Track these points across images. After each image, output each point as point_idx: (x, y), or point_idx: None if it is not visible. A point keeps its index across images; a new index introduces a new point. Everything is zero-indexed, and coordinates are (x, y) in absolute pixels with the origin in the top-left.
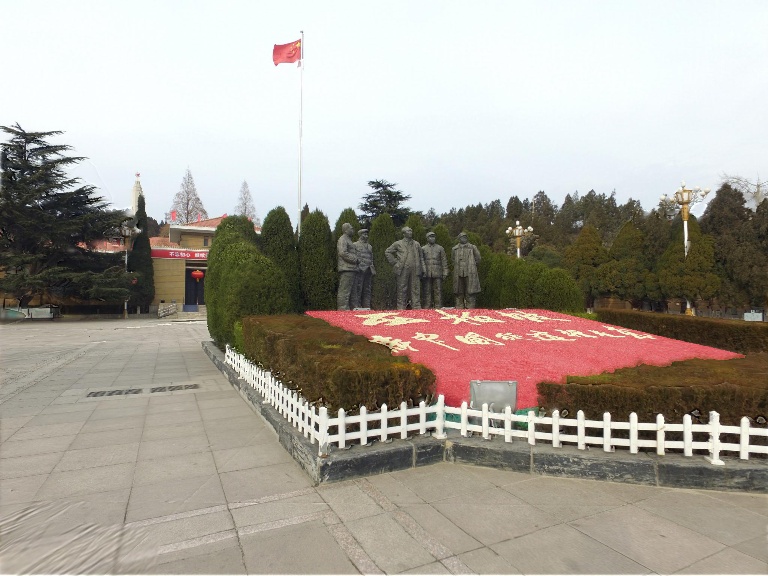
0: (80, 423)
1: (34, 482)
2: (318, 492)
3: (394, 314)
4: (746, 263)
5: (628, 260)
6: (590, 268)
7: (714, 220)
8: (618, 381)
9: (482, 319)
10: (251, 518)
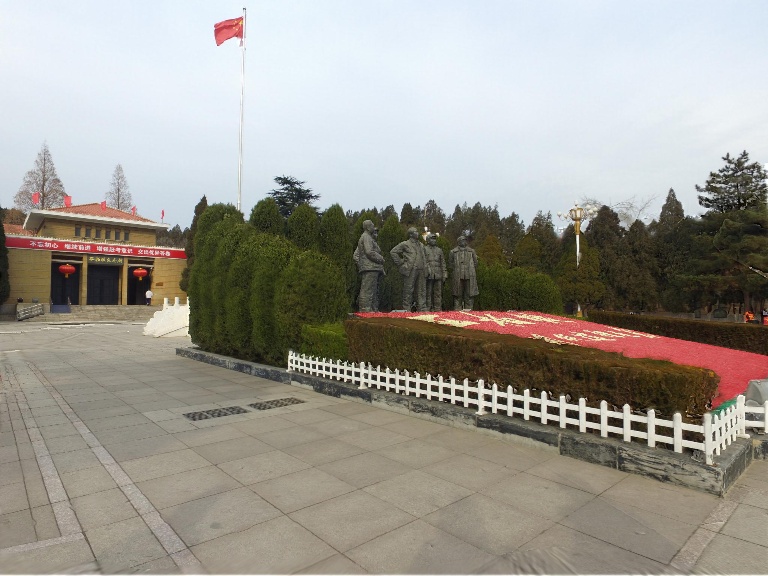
0: (279, 453)
1: (432, 532)
2: (742, 503)
3: (436, 316)
4: (625, 273)
5: (529, 267)
6: None
7: (598, 235)
8: None
9: (512, 321)
10: (764, 538)
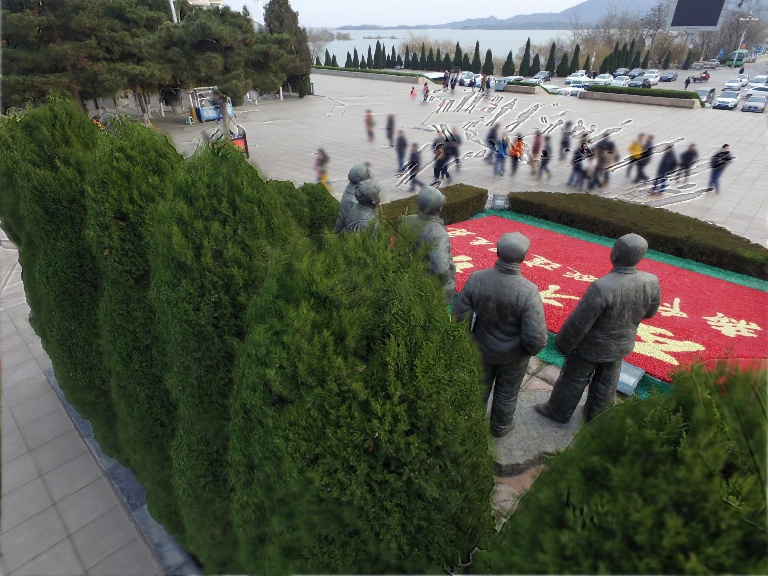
0: None
1: None
2: None
3: None
4: None
5: None
6: None
7: None
8: (759, 250)
9: None
10: None
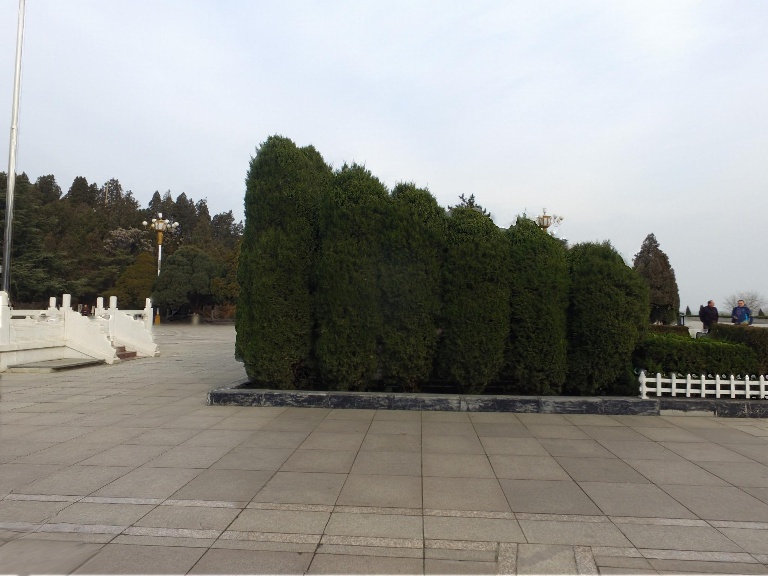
0: None
1: None
2: None
3: None
4: None
5: None
6: None
7: None
8: None
9: None
10: None
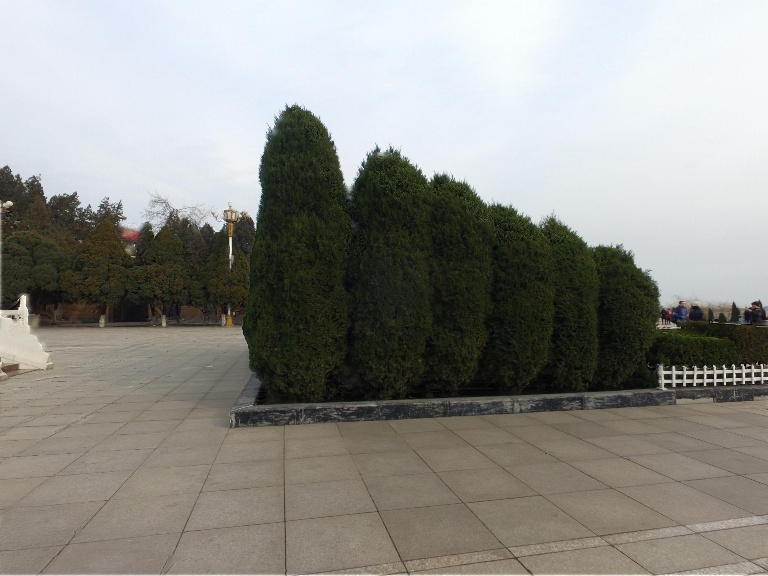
0: None
1: None
2: None
3: None
4: None
5: (175, 266)
6: (123, 269)
7: (242, 240)
8: None
9: None
10: None
